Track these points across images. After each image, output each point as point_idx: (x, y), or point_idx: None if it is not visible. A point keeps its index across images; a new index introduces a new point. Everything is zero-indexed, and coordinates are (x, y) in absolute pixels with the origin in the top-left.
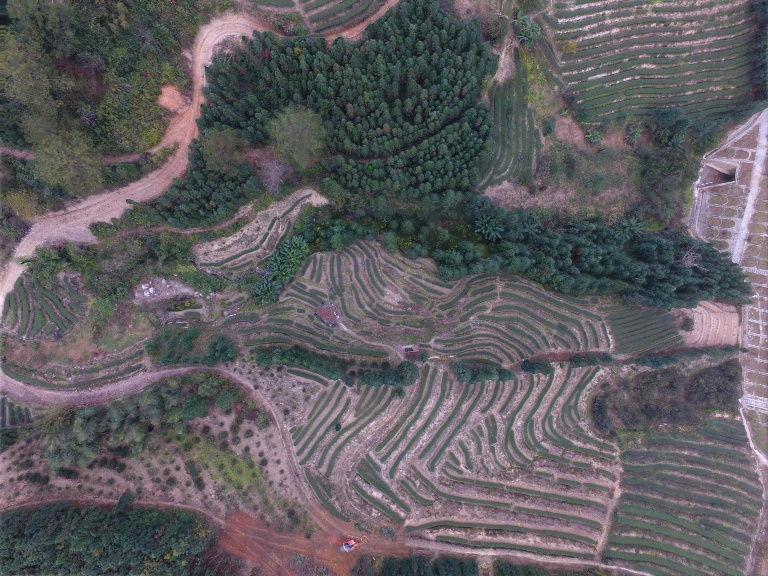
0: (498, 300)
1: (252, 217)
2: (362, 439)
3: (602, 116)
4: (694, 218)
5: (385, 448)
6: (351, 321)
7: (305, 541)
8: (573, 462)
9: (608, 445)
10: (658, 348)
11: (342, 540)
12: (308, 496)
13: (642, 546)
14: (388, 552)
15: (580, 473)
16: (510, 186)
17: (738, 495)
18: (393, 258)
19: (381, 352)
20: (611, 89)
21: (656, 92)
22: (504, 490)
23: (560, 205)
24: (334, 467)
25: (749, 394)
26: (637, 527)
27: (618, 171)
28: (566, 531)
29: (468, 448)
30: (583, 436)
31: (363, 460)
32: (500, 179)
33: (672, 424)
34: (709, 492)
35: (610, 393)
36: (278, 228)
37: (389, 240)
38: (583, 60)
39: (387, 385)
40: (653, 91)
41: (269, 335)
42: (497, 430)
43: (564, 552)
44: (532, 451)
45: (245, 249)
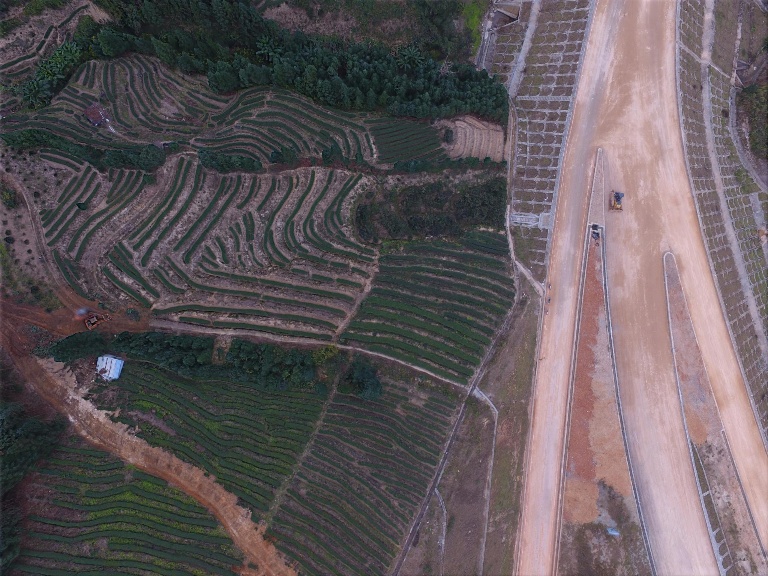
0: (264, 108)
1: (22, 19)
2: (116, 228)
3: None
4: (482, 58)
5: (139, 237)
6: (123, 127)
7: (45, 315)
8: (331, 262)
9: (368, 249)
10: (421, 159)
11: (85, 317)
12: (55, 276)
13: (381, 331)
14: (131, 331)
15: (335, 271)
16: (289, 9)
17: (488, 295)
18: (172, 74)
19: (139, 146)
20: None
21: None
22: (258, 283)
23: (344, 34)
24: (85, 252)
25: (515, 211)
26: (381, 316)
27: (397, 1)
28: (308, 316)
29: (225, 244)
30: (344, 240)
31: (115, 247)
32: (277, 0)
33: (437, 235)
34: (459, 291)
35: (375, 203)
36: (56, 38)
37: (155, 44)
38: None
39: (139, 173)
40: None
41: (31, 128)
42: (255, 227)
43: (302, 332)
44: (292, 252)
45: (22, 56)
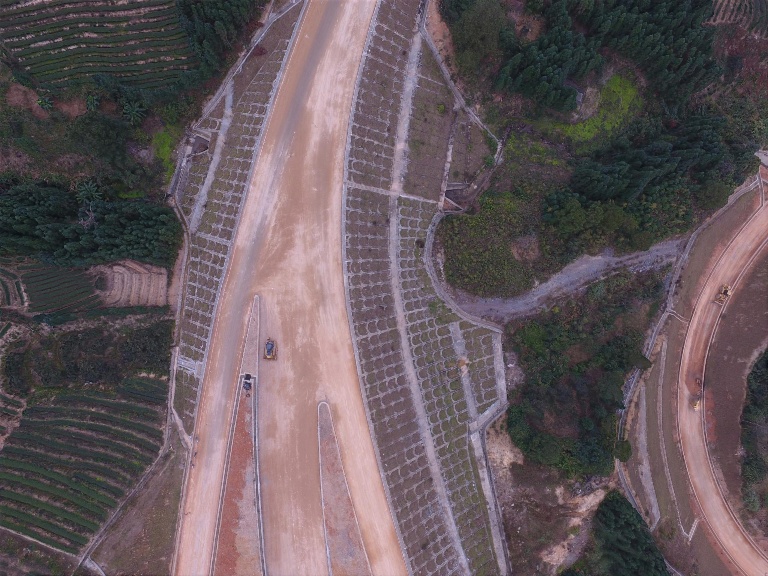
0: None
1: None
2: None
3: (55, 83)
4: (177, 186)
5: None
6: None
7: None
8: None
9: (15, 401)
10: (75, 307)
11: None
12: None
13: None
14: None
15: None
16: None
17: (129, 451)
18: None
19: None
20: (55, 56)
21: (104, 60)
22: None
23: (20, 169)
24: None
25: (181, 355)
26: (5, 479)
27: None
28: None
29: None
30: None
31: None
32: None
33: (95, 382)
34: (98, 447)
35: None
36: None
37: None
38: (22, 27)
39: None
40: (100, 59)
41: None
42: None
43: None
44: None
45: None
